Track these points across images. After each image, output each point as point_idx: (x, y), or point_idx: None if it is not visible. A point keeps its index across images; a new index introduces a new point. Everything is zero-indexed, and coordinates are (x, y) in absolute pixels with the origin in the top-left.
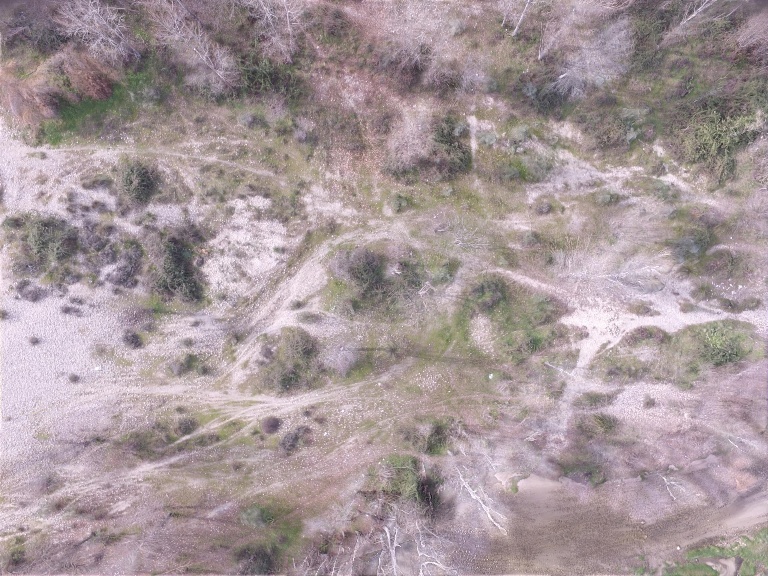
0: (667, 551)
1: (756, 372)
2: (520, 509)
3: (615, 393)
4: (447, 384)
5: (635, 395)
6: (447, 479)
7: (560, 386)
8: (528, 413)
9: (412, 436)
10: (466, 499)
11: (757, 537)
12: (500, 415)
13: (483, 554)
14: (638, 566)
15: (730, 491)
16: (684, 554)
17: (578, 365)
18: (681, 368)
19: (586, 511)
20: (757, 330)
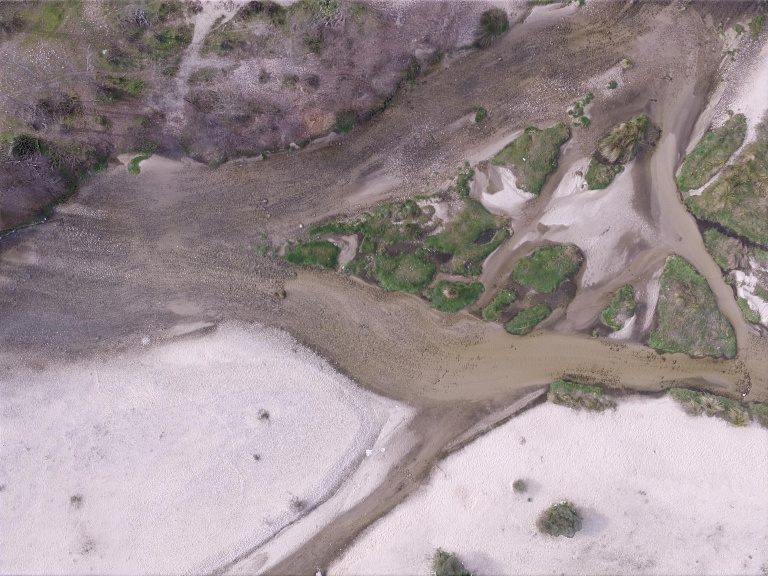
0: (290, 230)
1: (372, 46)
2: (143, 190)
3: (231, 68)
4: (61, 60)
5: (251, 70)
6: (63, 156)
7: (176, 62)
8: (143, 89)
9: (22, 110)
10: (89, 182)
11: (377, 212)
12: (110, 87)
13: (107, 236)
14: (261, 245)
15: (352, 169)
16: (307, 232)
17: (194, 41)
18: (295, 41)
19: (209, 191)
20: (371, 2)
